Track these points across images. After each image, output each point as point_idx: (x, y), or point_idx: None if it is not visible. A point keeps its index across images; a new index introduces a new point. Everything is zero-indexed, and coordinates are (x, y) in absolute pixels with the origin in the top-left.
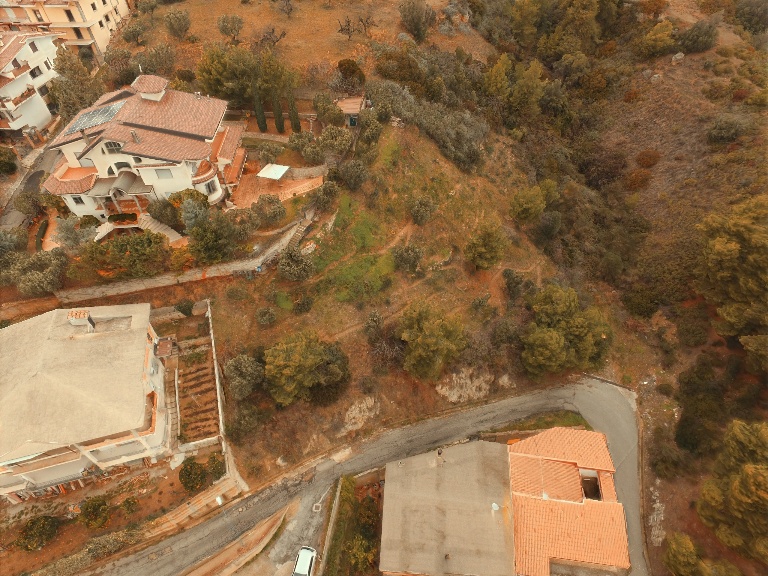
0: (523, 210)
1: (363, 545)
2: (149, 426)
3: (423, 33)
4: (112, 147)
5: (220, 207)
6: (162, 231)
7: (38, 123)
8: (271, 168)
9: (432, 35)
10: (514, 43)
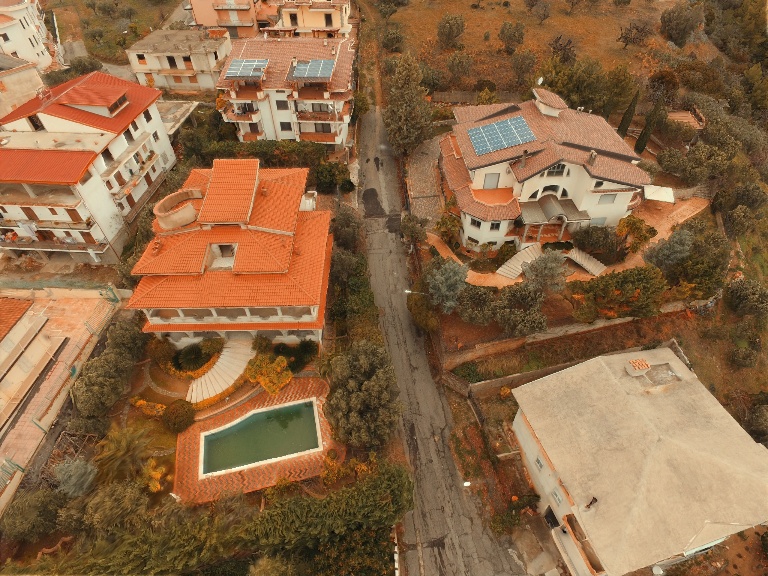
0: None
1: None
2: None
3: None
4: (554, 169)
5: None
6: (588, 261)
7: (345, 136)
8: (662, 190)
9: None
10: (746, 52)
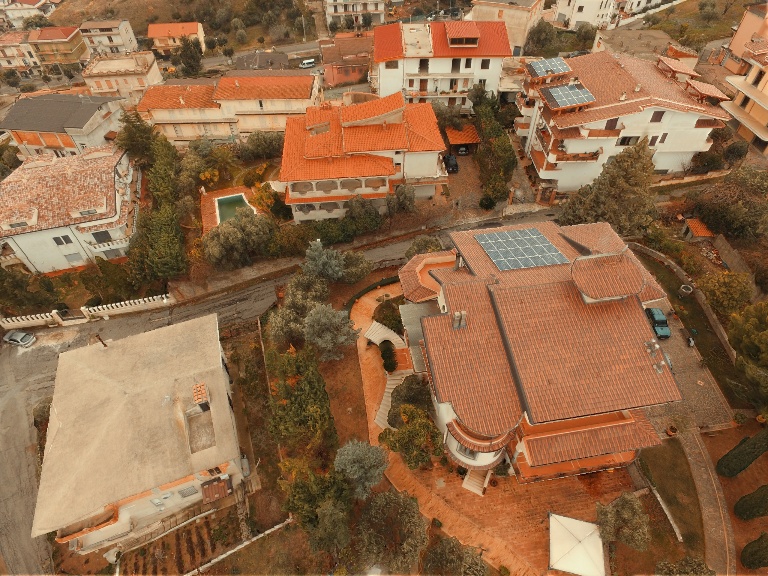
0: None
1: None
2: (71, 533)
3: None
4: None
5: (463, 471)
6: None
7: (572, 184)
8: (573, 542)
9: None
10: None
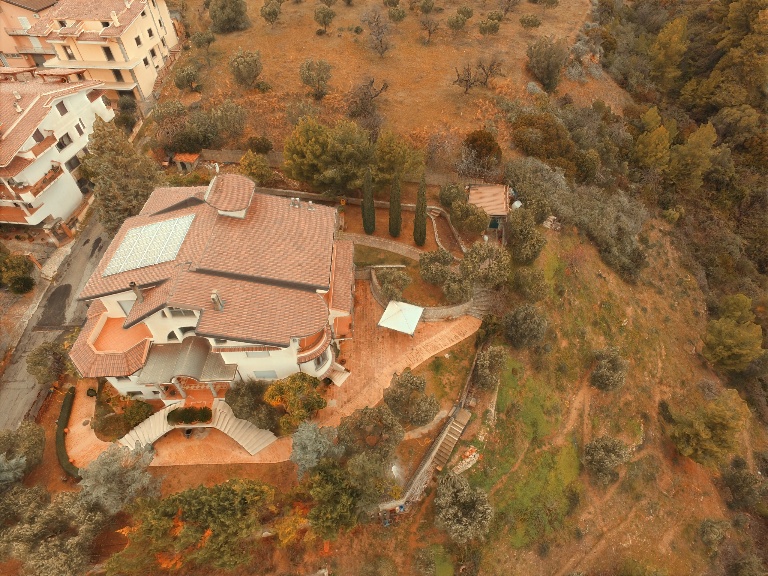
0: (730, 355)
1: None
2: None
3: (555, 82)
4: (178, 309)
5: (329, 380)
6: (247, 430)
7: (65, 209)
8: (400, 314)
9: (561, 82)
10: (654, 89)
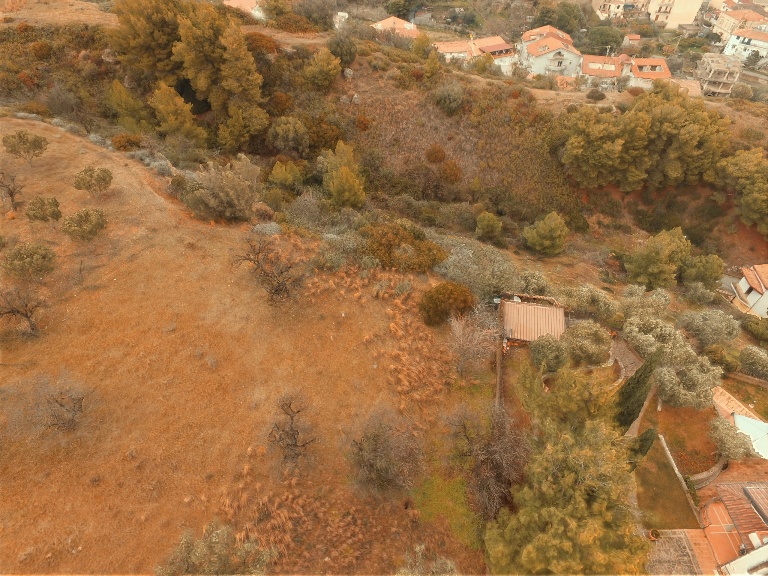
0: None
1: None
2: None
3: None
4: None
5: None
6: None
7: None
8: None
9: None
10: None
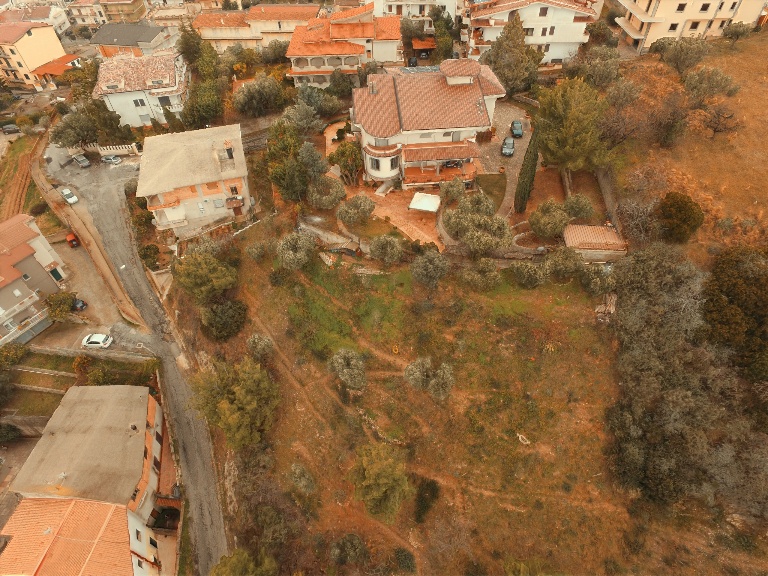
0: None
1: (99, 378)
2: None
3: None
4: None
5: (375, 185)
6: None
7: None
8: (423, 196)
9: None
10: None
